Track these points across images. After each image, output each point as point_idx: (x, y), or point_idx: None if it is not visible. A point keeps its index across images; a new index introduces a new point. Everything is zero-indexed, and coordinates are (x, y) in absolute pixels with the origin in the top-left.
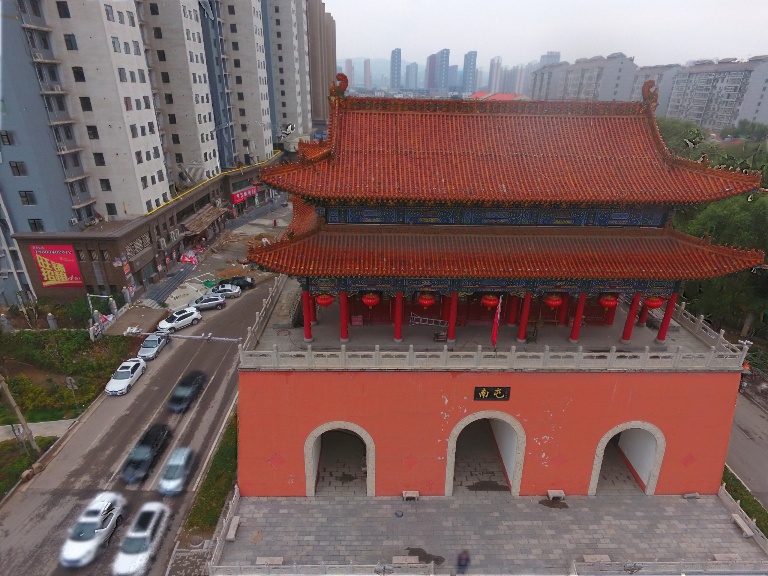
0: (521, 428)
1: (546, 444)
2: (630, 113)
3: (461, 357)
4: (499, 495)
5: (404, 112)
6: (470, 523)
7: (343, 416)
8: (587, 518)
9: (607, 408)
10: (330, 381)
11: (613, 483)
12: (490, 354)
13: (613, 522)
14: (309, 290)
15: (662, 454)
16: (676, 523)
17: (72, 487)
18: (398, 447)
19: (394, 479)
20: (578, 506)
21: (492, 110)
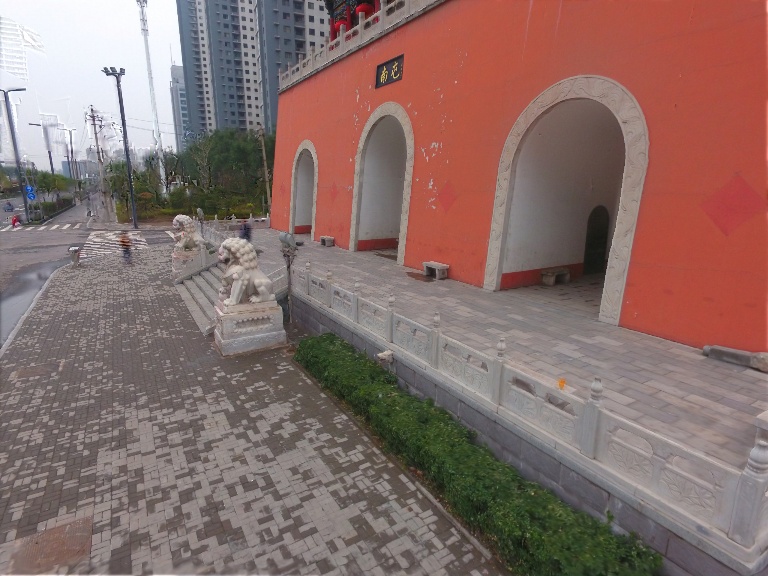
0: (411, 129)
1: (434, 159)
2: None
3: (372, 24)
4: (387, 260)
5: None
6: (321, 257)
7: (308, 133)
8: (423, 289)
9: (518, 57)
10: (306, 92)
11: (563, 298)
12: (391, 6)
13: (446, 301)
14: (334, 18)
15: (639, 178)
16: (564, 345)
17: None
18: (329, 172)
19: (324, 218)
20: (442, 285)
21: None
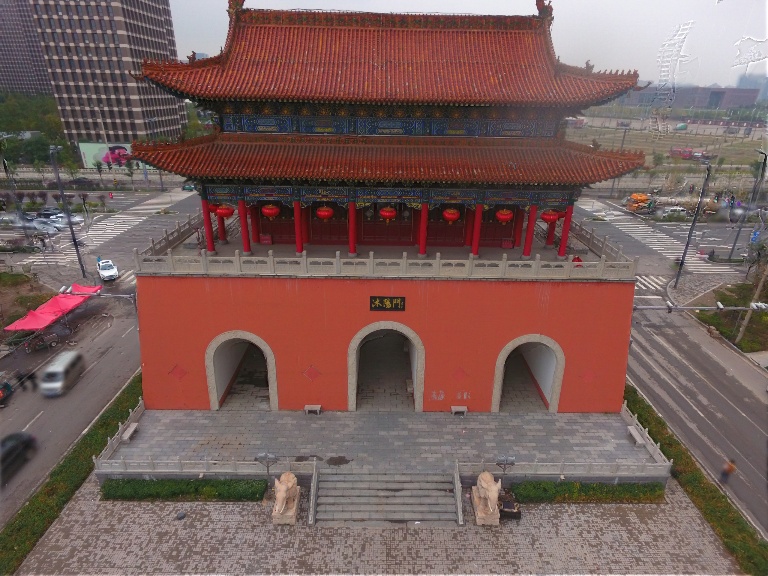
0: None
1: None
2: (255, 22)
3: None
4: None
5: (478, 30)
6: None
7: None
8: None
9: None
10: None
11: None
12: None
13: None
14: None
15: None
16: None
17: (670, 328)
18: None
19: None
20: None
21: (393, 25)
